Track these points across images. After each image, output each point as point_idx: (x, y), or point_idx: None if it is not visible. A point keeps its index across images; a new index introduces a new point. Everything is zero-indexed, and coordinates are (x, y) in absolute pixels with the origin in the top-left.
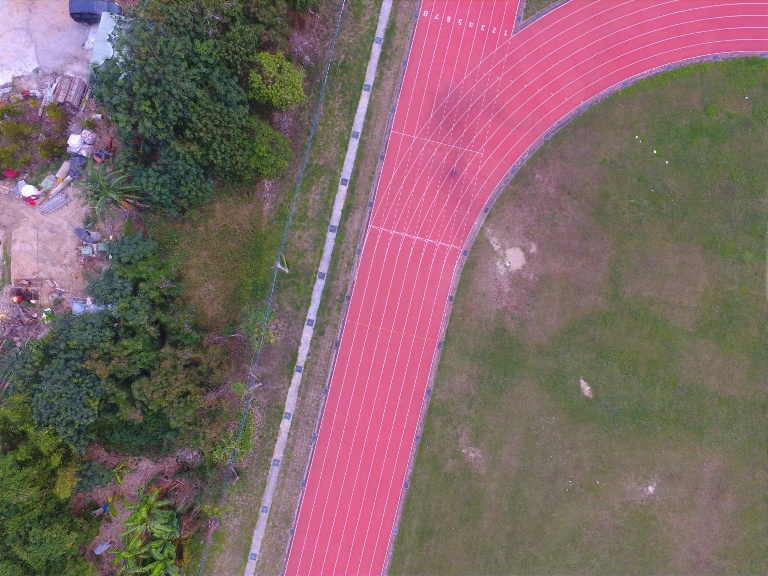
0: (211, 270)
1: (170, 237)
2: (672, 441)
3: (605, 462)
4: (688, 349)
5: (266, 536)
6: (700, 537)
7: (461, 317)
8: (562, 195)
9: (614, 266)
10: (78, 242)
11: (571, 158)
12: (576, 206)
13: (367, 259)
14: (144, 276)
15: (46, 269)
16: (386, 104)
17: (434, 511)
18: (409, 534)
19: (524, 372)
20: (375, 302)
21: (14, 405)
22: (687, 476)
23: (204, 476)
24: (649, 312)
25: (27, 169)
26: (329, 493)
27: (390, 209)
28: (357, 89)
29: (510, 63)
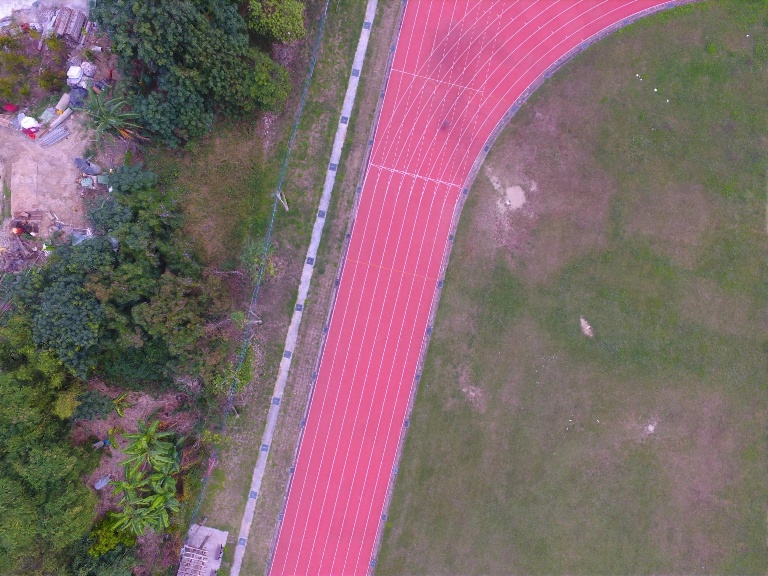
0: (211, 206)
1: (170, 171)
2: (672, 380)
3: (605, 401)
4: (689, 288)
5: (266, 474)
6: (700, 476)
7: (461, 256)
8: (562, 133)
9: (614, 205)
10: (78, 175)
11: (571, 96)
12: (576, 144)
13: (367, 197)
14: (144, 205)
15: (46, 202)
16: (386, 42)
17: (434, 450)
18: (409, 473)
19: (524, 311)
20: (375, 240)
21: (14, 327)
22: (687, 415)
23: (204, 407)
24: (649, 251)
25: (27, 103)
26: (329, 432)
27: (390, 147)
28: (357, 27)
29: (510, 1)
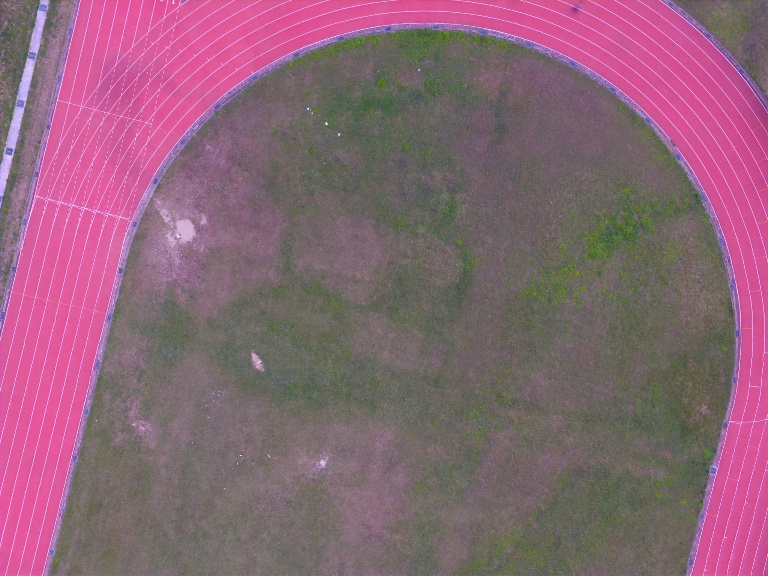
0: None
1: None
2: (344, 415)
3: (276, 436)
4: (361, 323)
5: None
6: (372, 511)
7: (131, 289)
8: (233, 167)
9: (285, 239)
10: None
11: (242, 129)
12: (247, 178)
13: (33, 230)
14: None
15: None
16: (52, 72)
17: (103, 485)
18: (77, 508)
19: (194, 345)
20: (41, 273)
21: None
22: (359, 450)
23: None
24: (321, 285)
25: None
26: None
27: (57, 179)
28: (21, 57)
29: (178, 32)
